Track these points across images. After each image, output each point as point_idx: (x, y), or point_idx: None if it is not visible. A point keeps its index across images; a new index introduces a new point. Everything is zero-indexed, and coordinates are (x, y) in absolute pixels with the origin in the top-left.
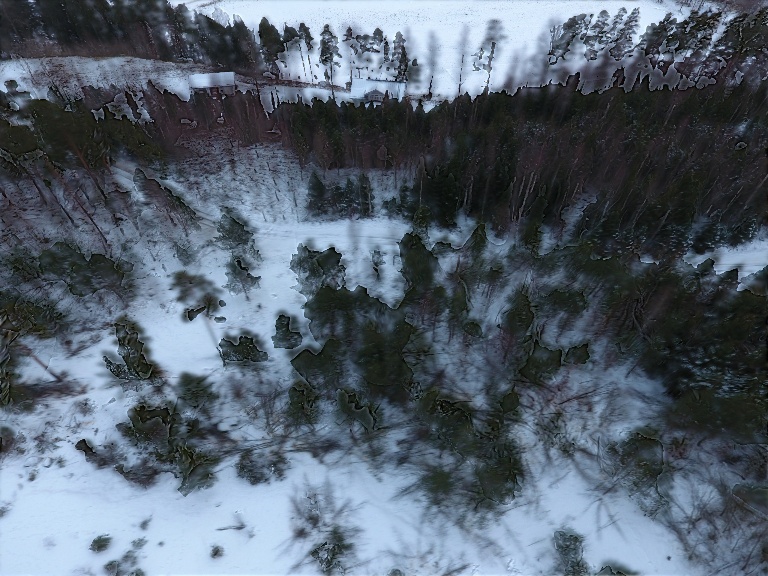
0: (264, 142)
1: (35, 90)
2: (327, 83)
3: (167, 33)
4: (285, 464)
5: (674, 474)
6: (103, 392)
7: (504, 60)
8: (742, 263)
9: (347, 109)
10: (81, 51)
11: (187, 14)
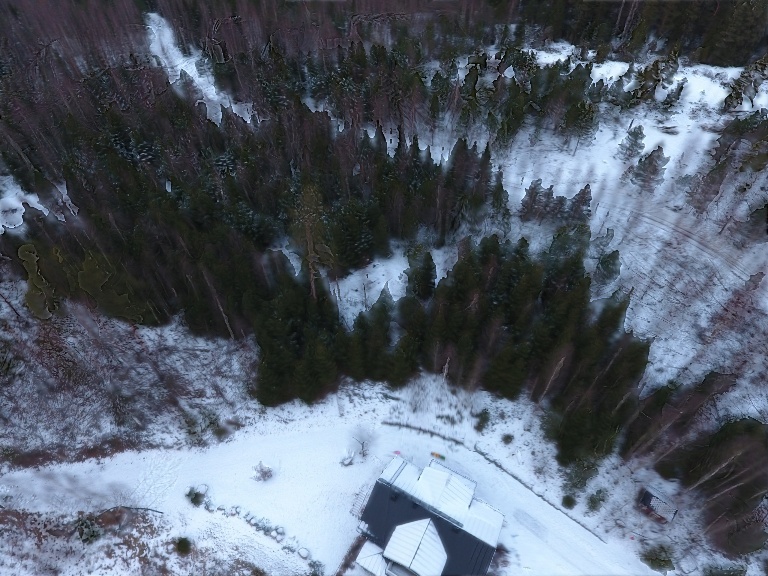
0: None
1: None
2: None
3: None
4: (588, 91)
5: (424, 81)
6: (691, 123)
7: None
8: None
9: (536, 333)
10: None
11: None
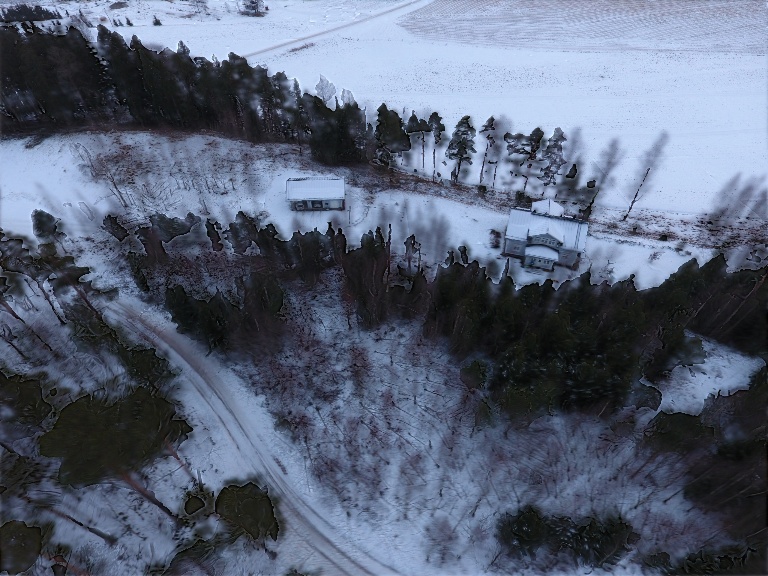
0: (394, 321)
1: (94, 186)
2: (452, 182)
3: (259, 107)
4: None
5: None
6: None
7: (667, 151)
8: None
9: (531, 295)
10: (155, 120)
11: (285, 84)
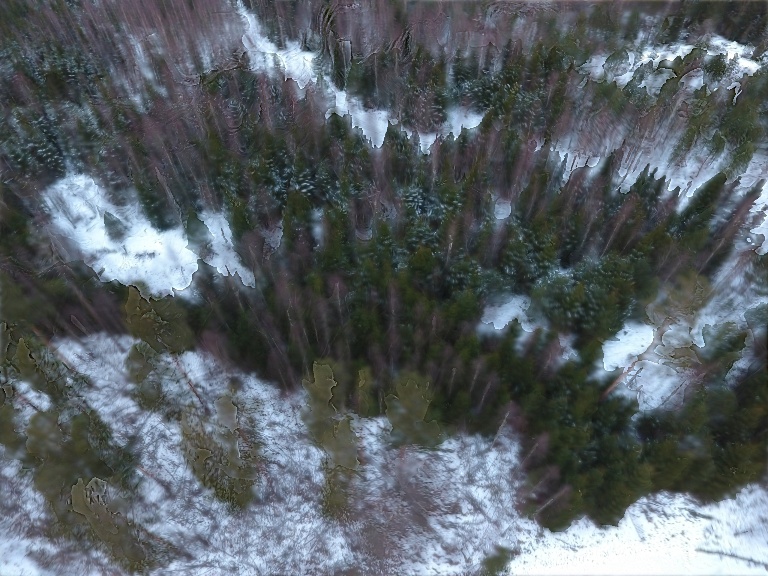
0: None
1: None
2: None
3: None
4: None
5: None
6: None
7: None
8: (425, 146)
9: None
10: None
11: None
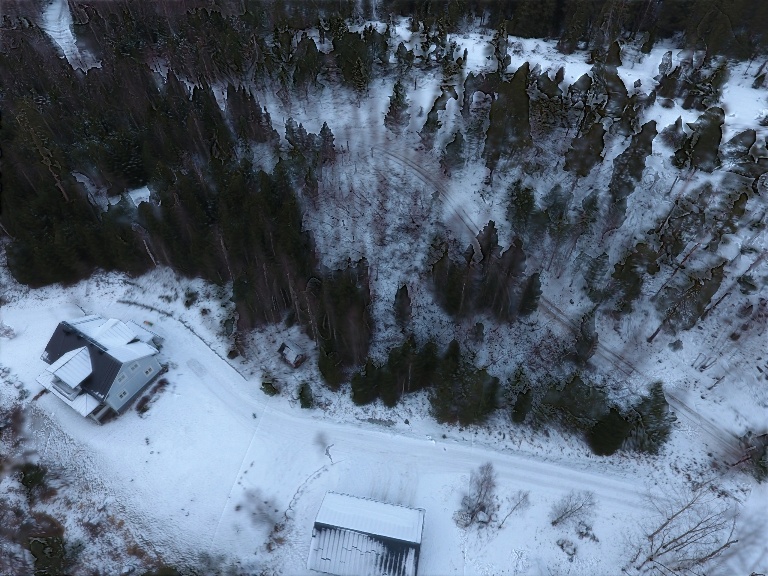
0: None
1: None
2: None
3: None
4: None
5: None
6: None
7: None
8: None
9: None
10: None
11: None
